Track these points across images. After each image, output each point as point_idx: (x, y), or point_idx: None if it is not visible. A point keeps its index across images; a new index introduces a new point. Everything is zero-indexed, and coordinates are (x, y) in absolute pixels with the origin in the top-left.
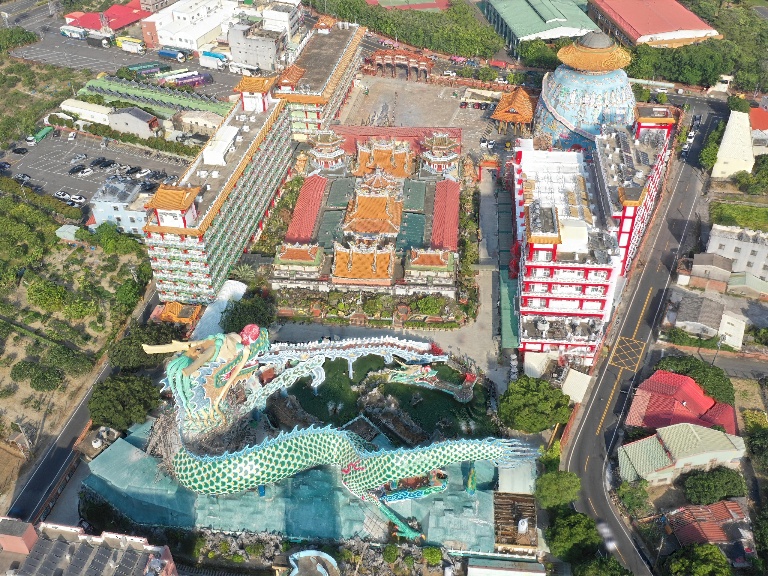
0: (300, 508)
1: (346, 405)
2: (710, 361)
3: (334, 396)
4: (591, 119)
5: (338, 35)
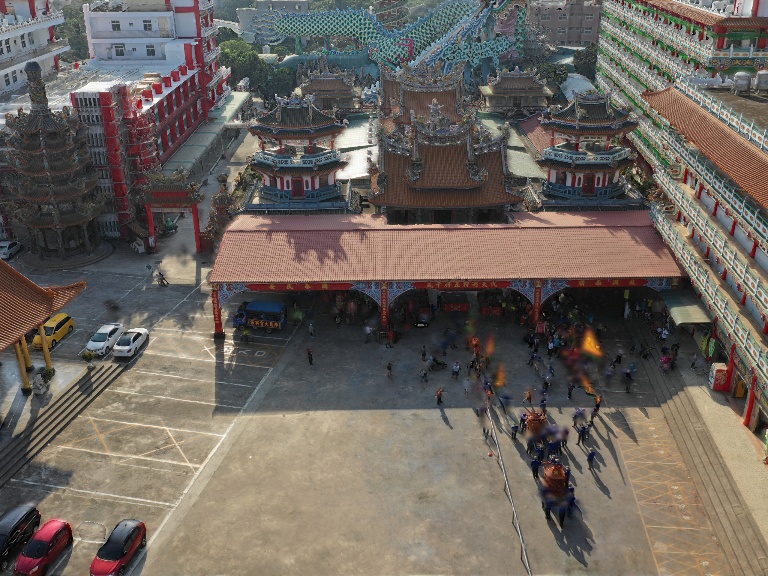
0: None
1: None
2: None
3: None
4: None
5: None
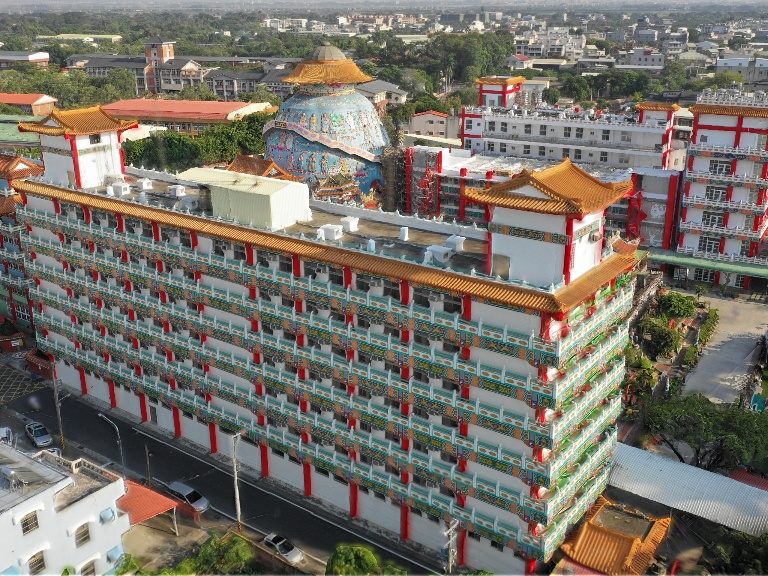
0: None
1: None
2: None
3: None
4: (379, 142)
5: None
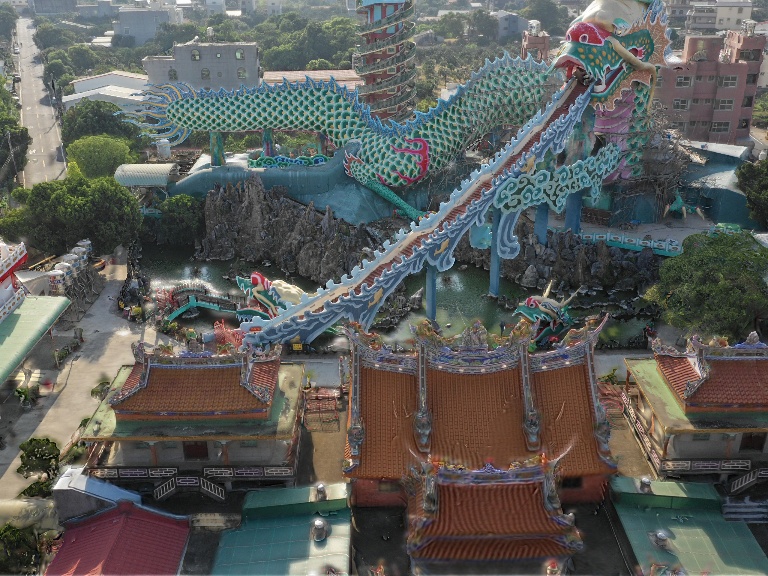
0: None
1: None
2: None
3: None
4: None
5: None
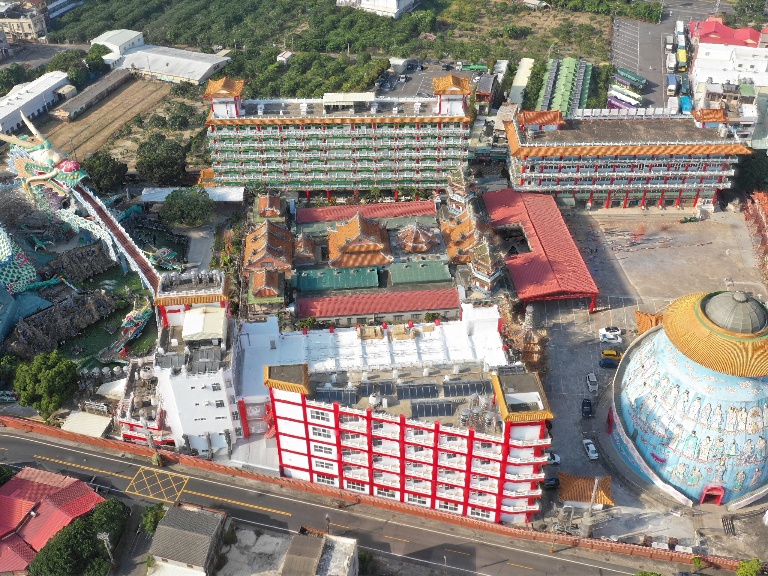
0: None
1: (111, 290)
2: (137, 571)
3: (122, 282)
4: (632, 392)
5: (699, 134)
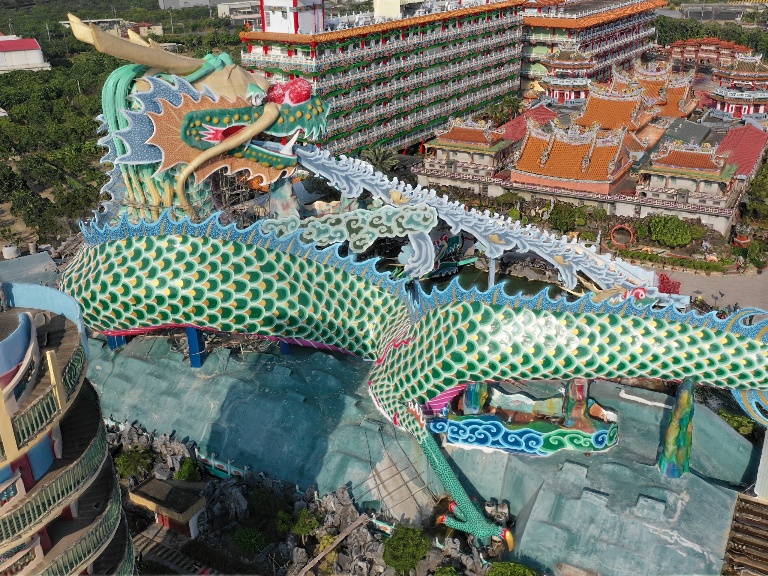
0: (252, 403)
1: None
2: None
3: None
4: None
5: None
